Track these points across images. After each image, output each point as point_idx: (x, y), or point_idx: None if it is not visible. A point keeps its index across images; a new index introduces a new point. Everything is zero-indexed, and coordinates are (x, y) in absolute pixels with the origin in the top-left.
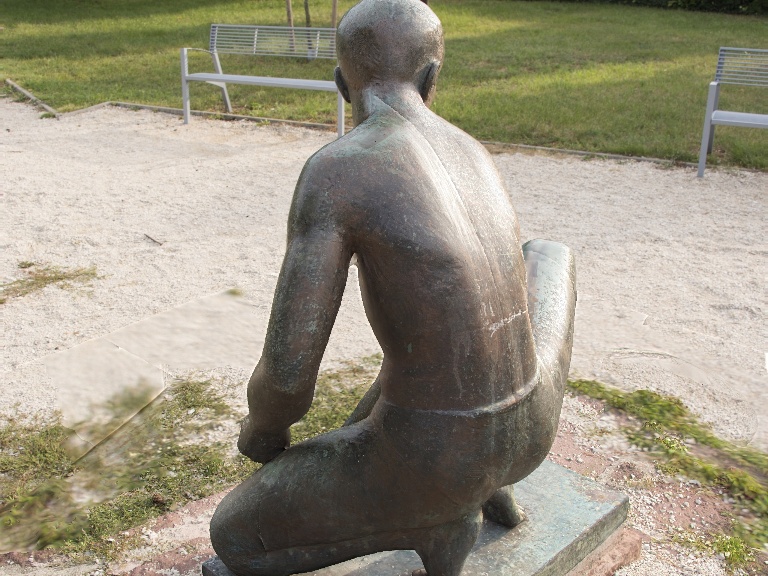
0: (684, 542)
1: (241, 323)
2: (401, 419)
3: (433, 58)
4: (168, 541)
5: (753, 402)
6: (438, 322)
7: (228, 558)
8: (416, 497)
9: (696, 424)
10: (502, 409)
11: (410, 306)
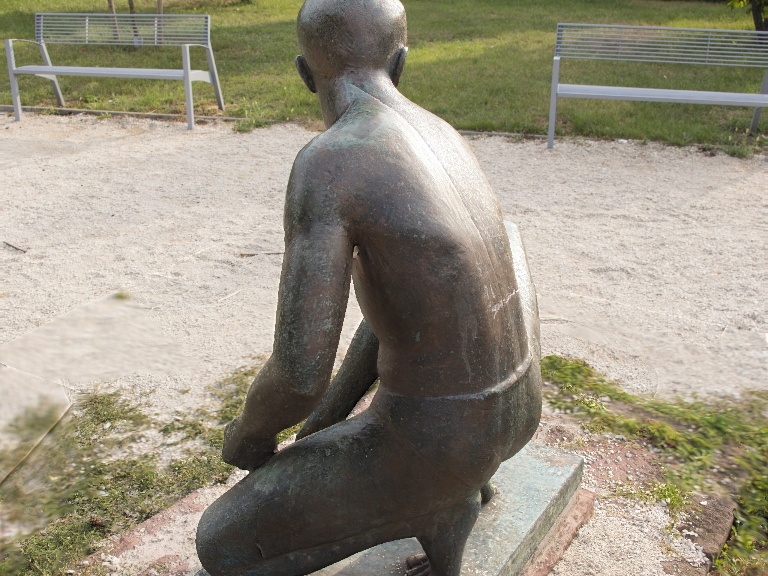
0: (627, 494)
1: (137, 328)
2: (411, 409)
3: (401, 44)
4: (133, 564)
5: (649, 357)
6: (446, 308)
7: (221, 572)
8: (430, 484)
9: (605, 383)
10: (507, 388)
11: (418, 295)
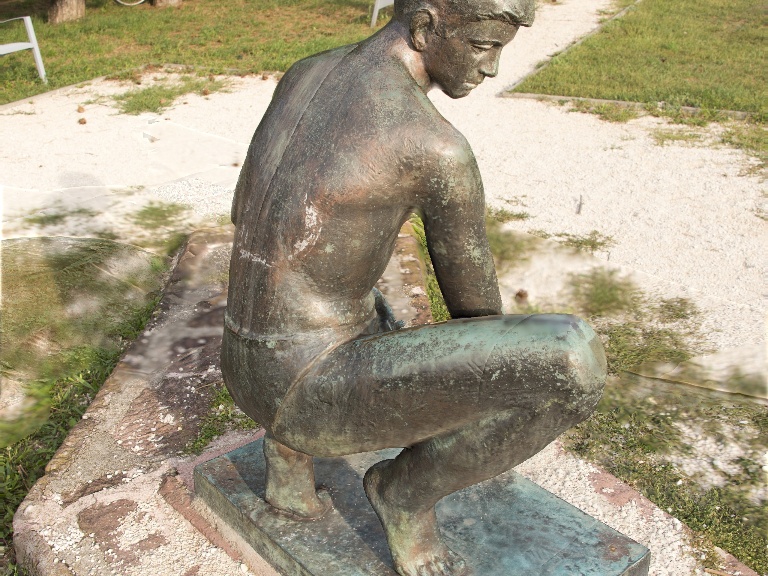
0: None
1: None
2: None
3: (426, 3)
4: None
5: None
6: None
7: None
8: None
9: None
10: None
11: None
